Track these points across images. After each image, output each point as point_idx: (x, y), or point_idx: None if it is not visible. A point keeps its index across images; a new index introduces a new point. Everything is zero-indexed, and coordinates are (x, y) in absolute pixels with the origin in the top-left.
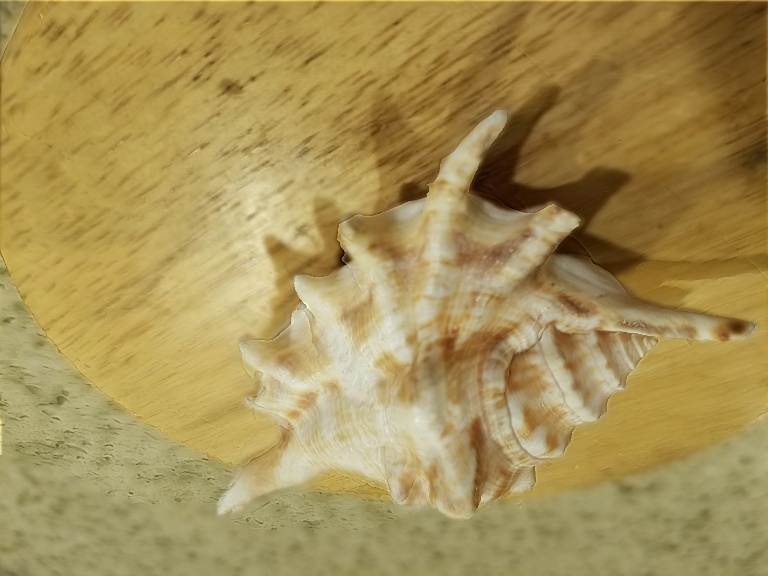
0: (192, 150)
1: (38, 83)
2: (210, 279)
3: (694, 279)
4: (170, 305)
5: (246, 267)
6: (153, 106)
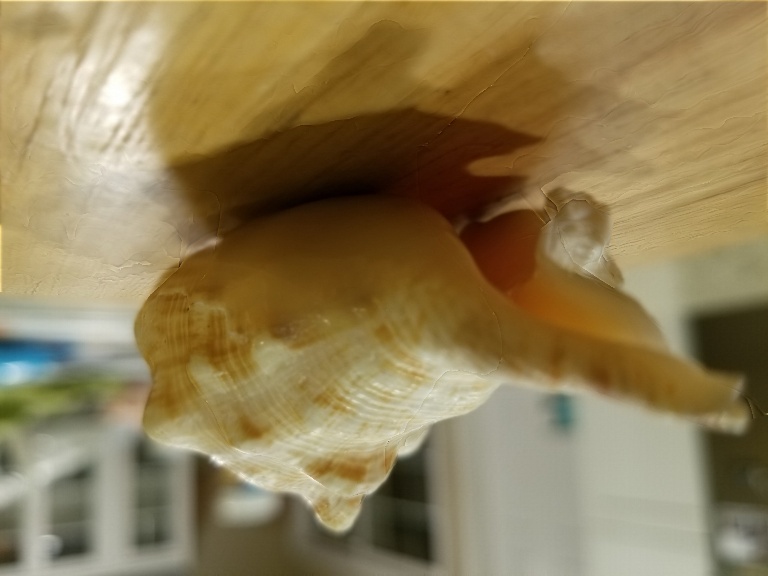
0: (630, 231)
1: (740, 228)
2: (662, 180)
3: (132, 268)
4: (756, 149)
5: (604, 198)
6: (651, 237)
